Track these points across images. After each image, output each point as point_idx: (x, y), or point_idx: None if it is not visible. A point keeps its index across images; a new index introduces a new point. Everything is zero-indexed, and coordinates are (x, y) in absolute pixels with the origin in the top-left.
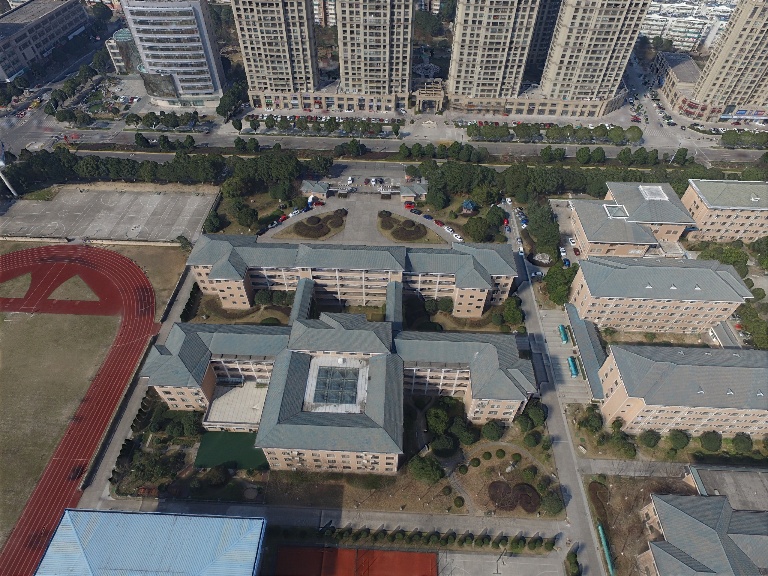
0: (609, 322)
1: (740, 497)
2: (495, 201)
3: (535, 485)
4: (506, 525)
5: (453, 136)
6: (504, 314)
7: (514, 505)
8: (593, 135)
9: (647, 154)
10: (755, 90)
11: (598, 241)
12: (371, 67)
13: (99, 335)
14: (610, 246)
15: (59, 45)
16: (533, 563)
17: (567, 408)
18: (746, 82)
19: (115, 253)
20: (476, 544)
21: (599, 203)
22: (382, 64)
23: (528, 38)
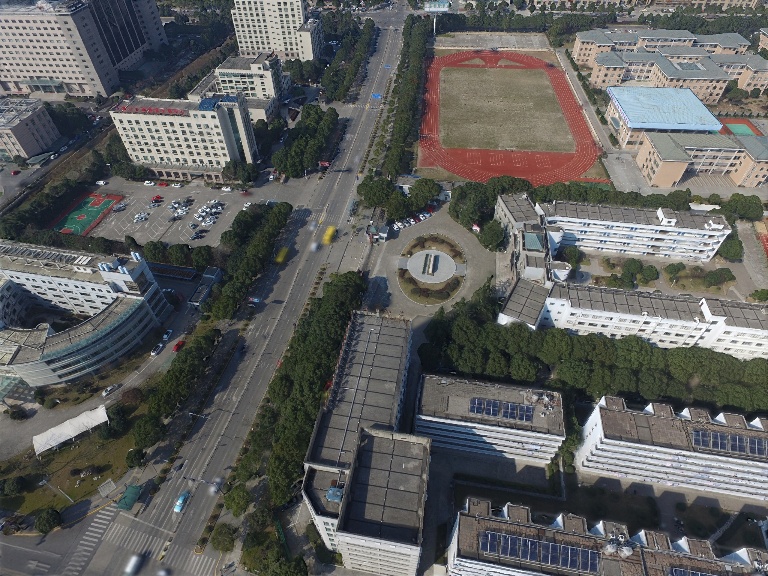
0: None
1: None
2: None
3: None
4: None
5: None
6: None
7: None
8: (755, 12)
9: None
10: None
11: None
12: None
13: None
14: None
15: None
16: None
17: None
18: None
19: None
20: (764, 117)
21: None
22: None
23: None
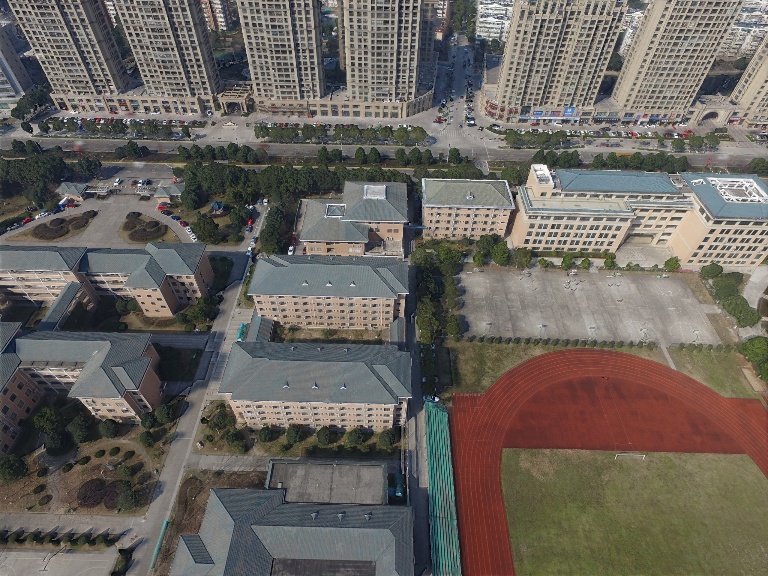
0: (289, 320)
1: (301, 489)
2: (249, 201)
3: (132, 482)
4: (80, 522)
5: (248, 138)
6: (189, 313)
7: (97, 502)
8: (379, 136)
9: (421, 154)
10: (548, 91)
11: (309, 240)
12: (166, 69)
13: None
14: (327, 245)
15: None
16: (86, 559)
17: (208, 405)
18: (535, 83)
19: None
20: (37, 542)
21: (328, 202)
22: (176, 66)
23: (313, 40)
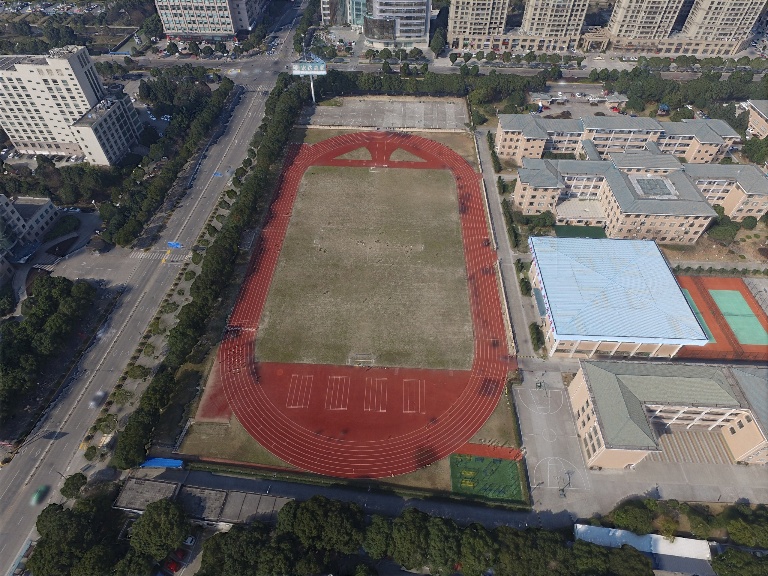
0: None
1: None
2: (681, 106)
3: None
4: None
5: (622, 68)
6: None
7: None
8: (738, 64)
9: None
10: None
11: None
12: (556, 13)
13: (443, 179)
14: None
15: (267, 4)
16: None
17: None
18: None
19: (416, 136)
20: (764, 274)
21: None
22: (566, 10)
23: None
